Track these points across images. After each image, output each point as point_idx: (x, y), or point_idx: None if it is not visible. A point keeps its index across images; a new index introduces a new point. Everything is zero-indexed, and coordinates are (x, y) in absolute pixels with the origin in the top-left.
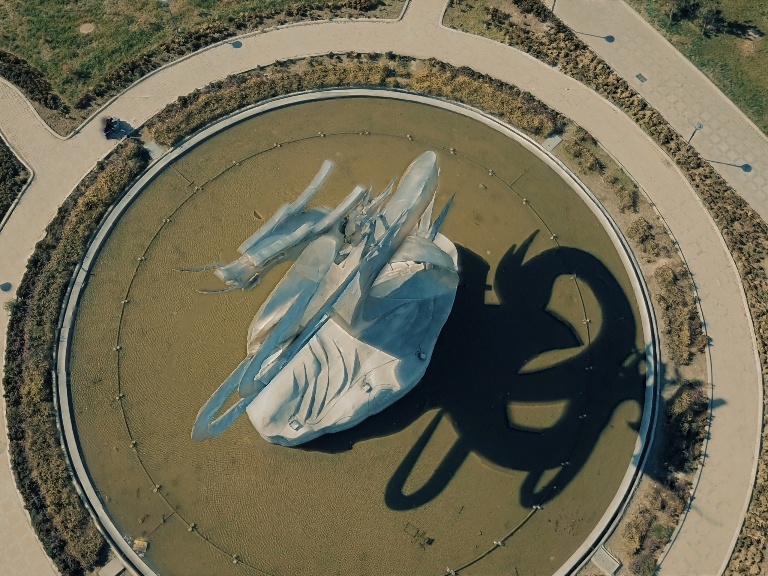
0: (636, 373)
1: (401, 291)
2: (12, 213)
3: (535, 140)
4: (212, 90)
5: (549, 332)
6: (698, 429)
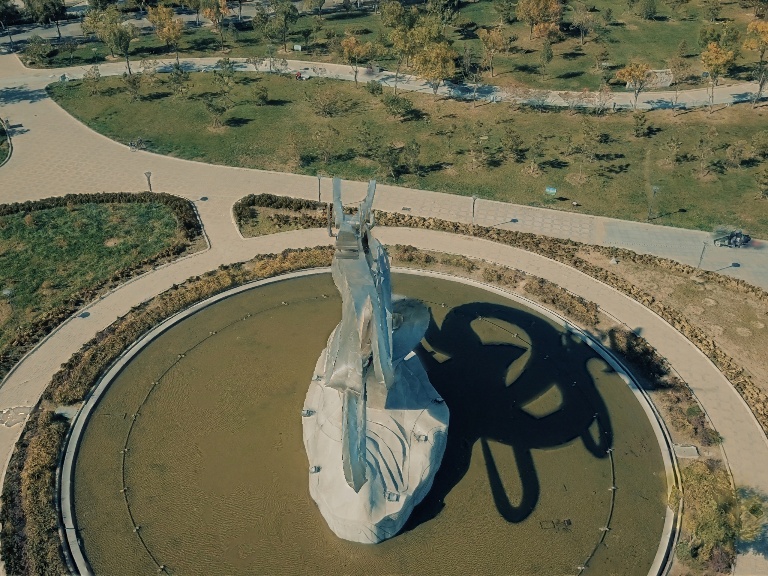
0: (576, 344)
1: None
2: None
3: None
4: (90, 346)
5: (499, 354)
6: (645, 347)
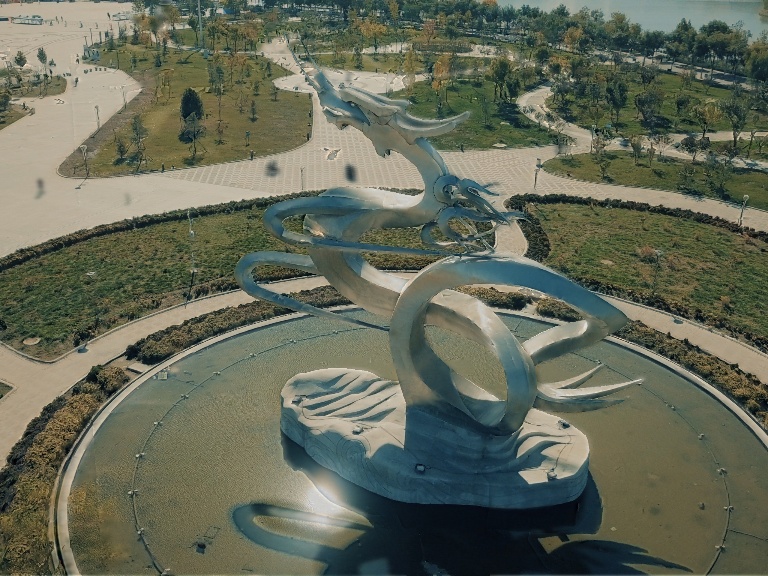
0: None
1: (475, 403)
2: None
3: None
4: None
5: None
6: None
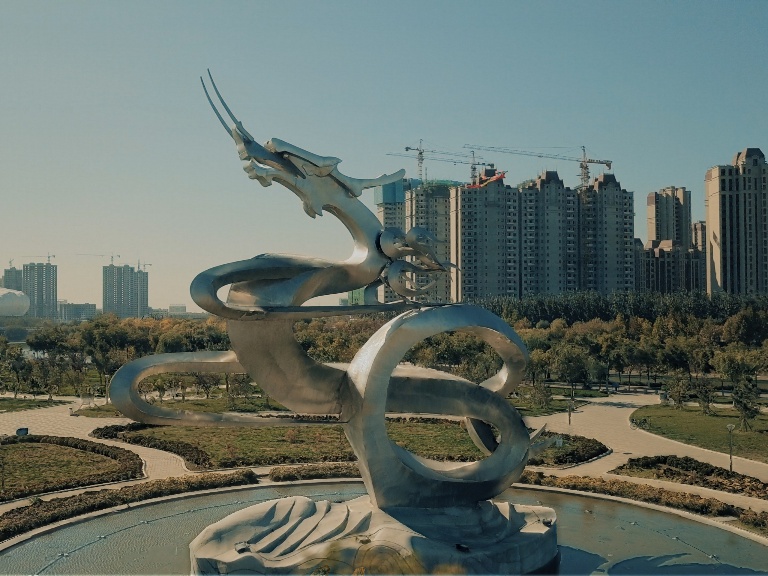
0: None
1: (455, 473)
2: (104, 485)
3: None
4: None
5: None
6: None
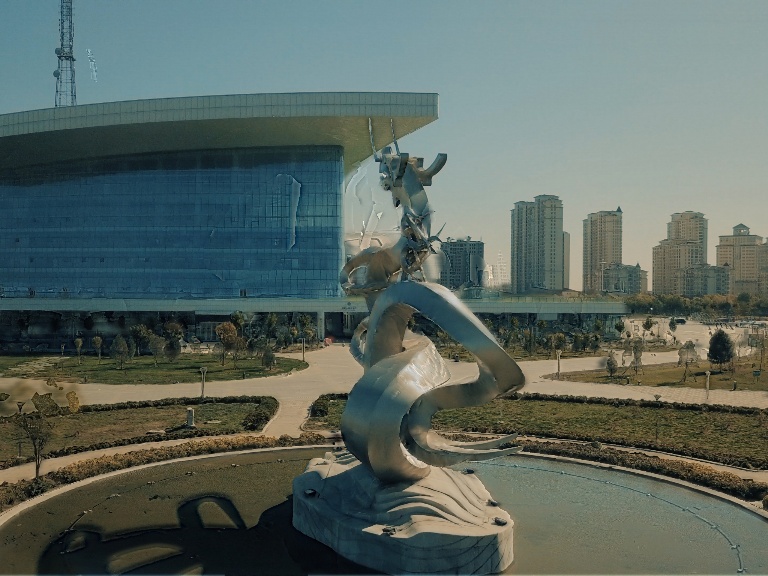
0: None
1: None
2: None
3: None
4: None
5: None
6: None
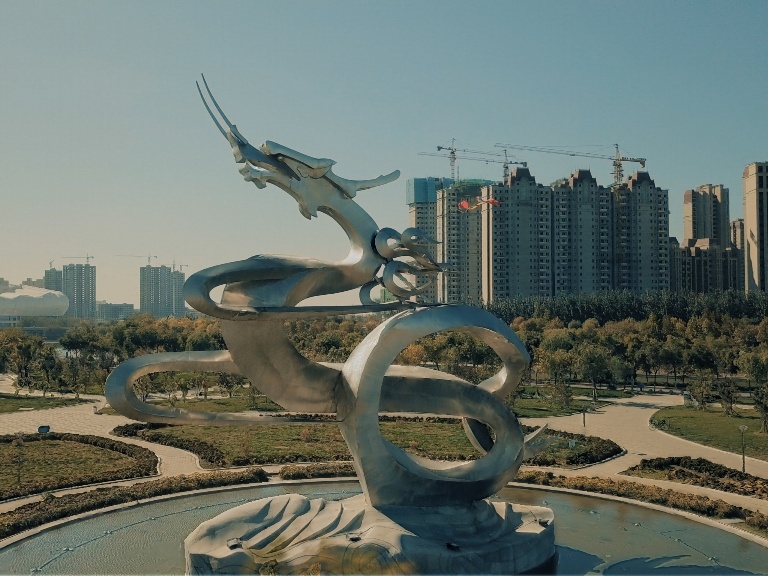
0: None
1: (450, 472)
2: (118, 482)
3: (706, 517)
4: None
5: None
6: None
